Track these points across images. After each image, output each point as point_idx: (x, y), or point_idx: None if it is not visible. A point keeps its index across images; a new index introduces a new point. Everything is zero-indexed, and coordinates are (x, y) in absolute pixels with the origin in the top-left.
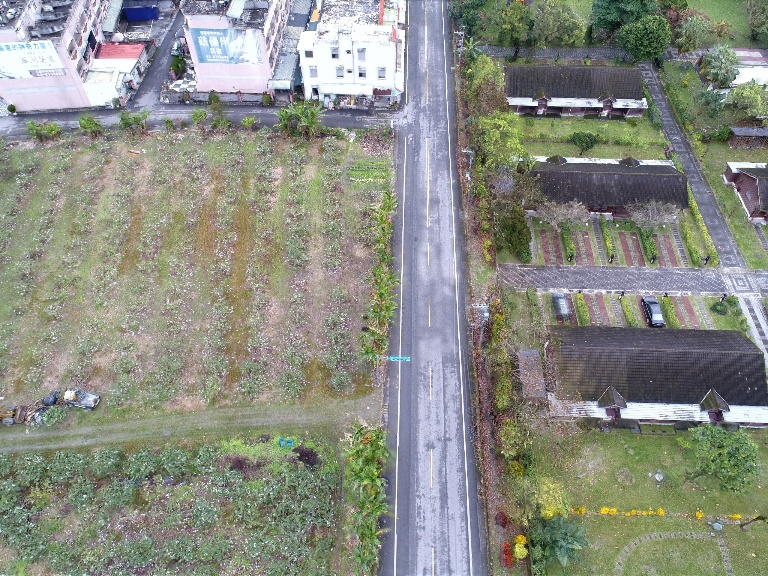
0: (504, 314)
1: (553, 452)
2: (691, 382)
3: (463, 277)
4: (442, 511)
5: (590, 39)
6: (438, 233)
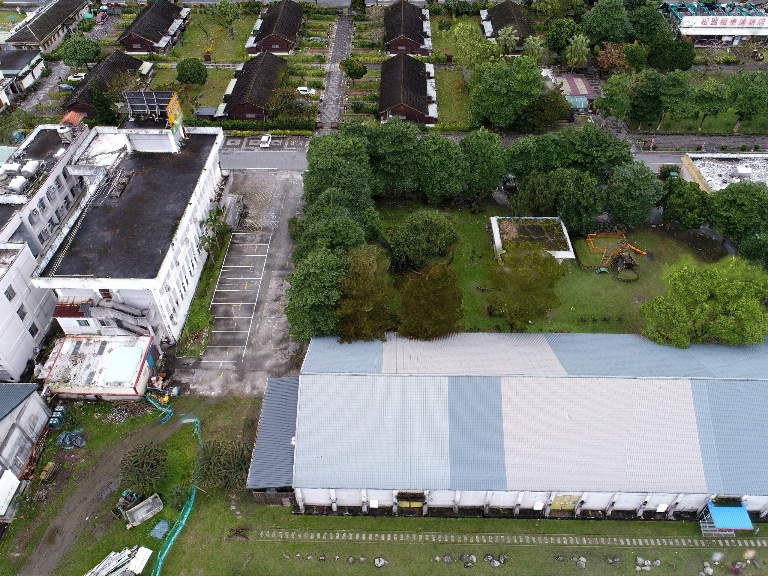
0: (317, 8)
1: (252, 18)
2: (266, 25)
3: (344, 6)
4: (235, 0)
5: (588, 45)
6: (373, 2)
